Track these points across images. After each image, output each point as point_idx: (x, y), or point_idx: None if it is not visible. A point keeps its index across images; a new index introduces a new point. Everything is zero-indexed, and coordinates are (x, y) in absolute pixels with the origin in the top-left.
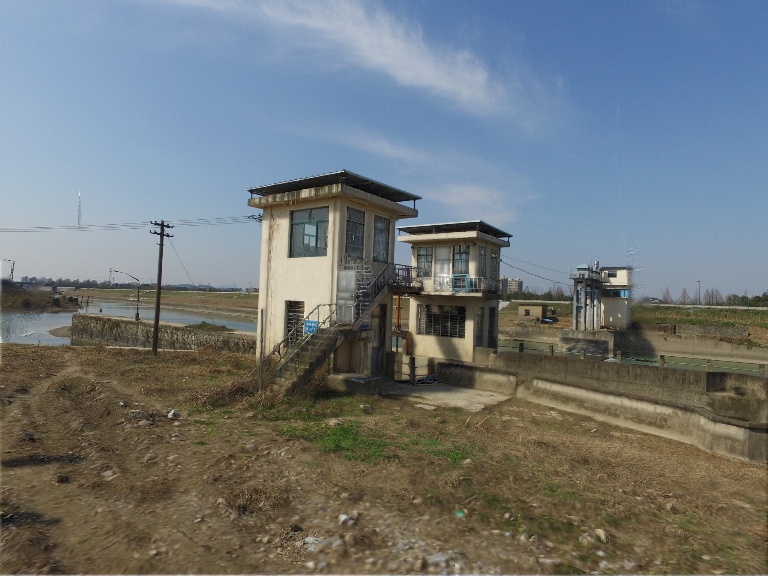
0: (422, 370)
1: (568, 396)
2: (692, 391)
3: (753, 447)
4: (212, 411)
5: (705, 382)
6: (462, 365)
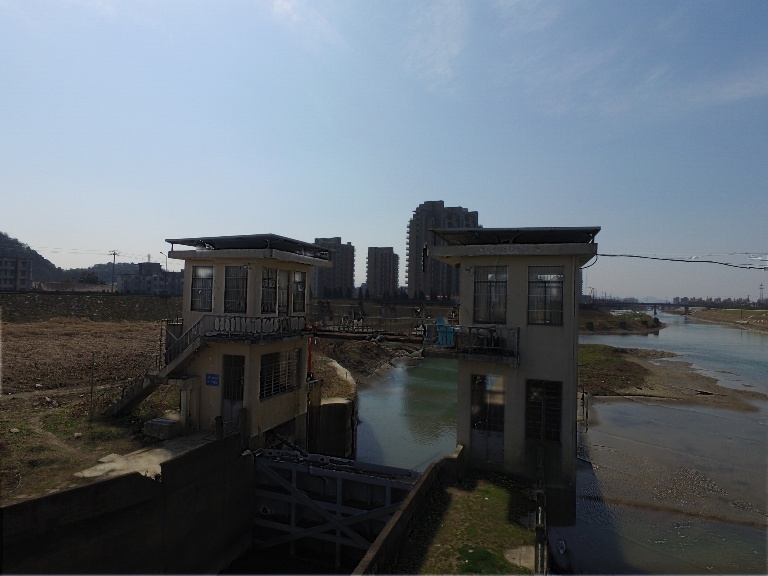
0: None
1: None
2: None
3: None
4: None
5: None
6: None
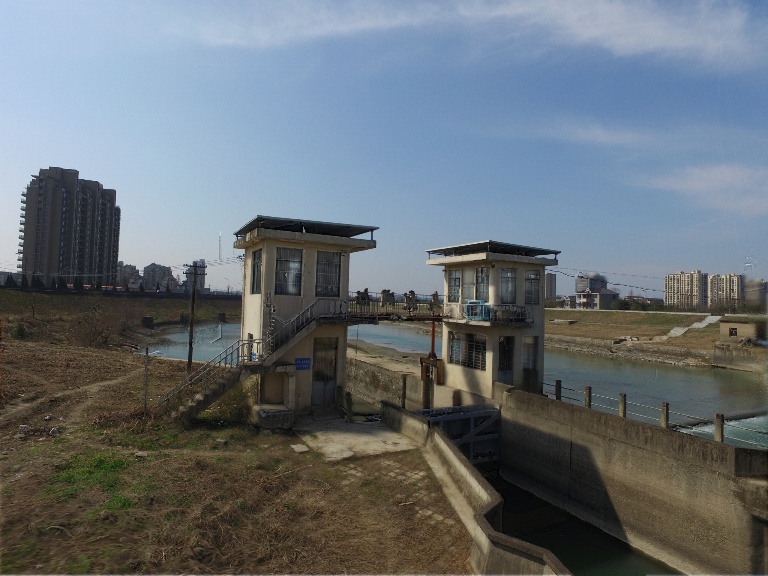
0: (448, 402)
1: (445, 457)
2: (715, 472)
3: (492, 567)
4: (92, 431)
5: (732, 462)
6: (395, 406)
